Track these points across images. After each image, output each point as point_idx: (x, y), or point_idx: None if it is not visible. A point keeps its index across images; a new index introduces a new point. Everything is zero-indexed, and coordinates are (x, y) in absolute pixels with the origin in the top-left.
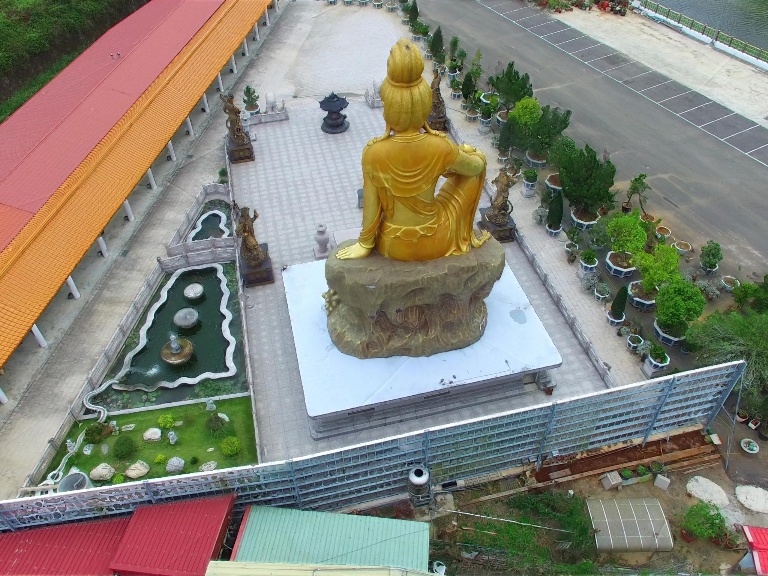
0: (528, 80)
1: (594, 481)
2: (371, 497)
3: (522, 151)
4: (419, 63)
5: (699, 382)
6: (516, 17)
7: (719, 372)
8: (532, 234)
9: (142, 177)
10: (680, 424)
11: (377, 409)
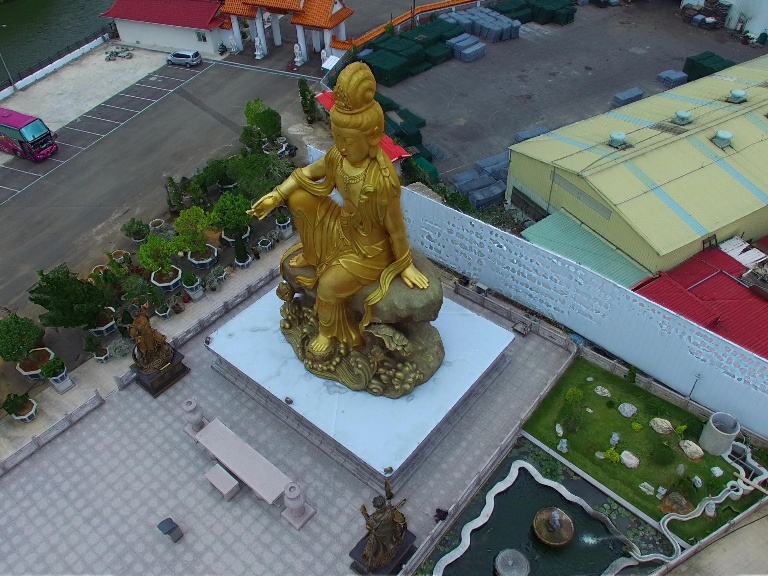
0: None
1: None
2: None
3: None
4: None
5: None
6: None
7: None
8: None
9: None
10: None
11: None
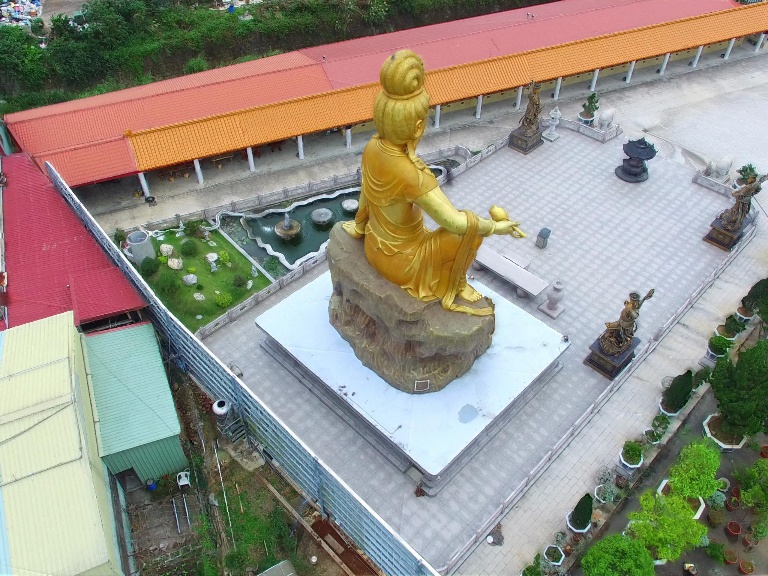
0: None
1: None
2: None
3: None
4: (397, 78)
5: None
6: None
7: None
8: (643, 393)
9: None
10: None
11: None
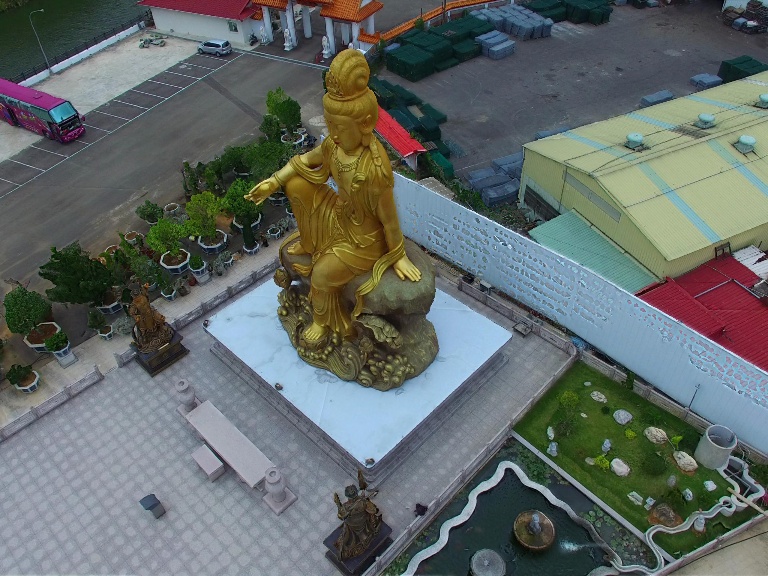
0: None
1: None
2: None
3: None
4: None
5: None
6: None
7: None
8: None
9: None
10: None
11: None
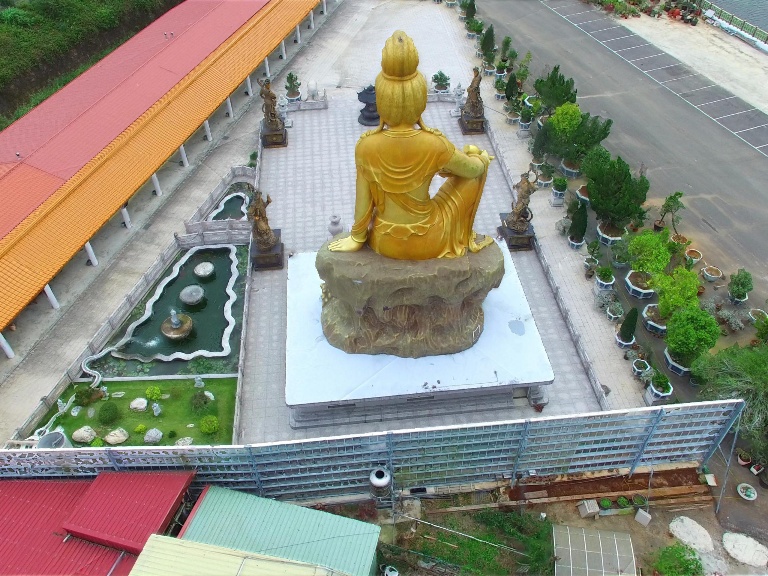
0: (572, 85)
1: (571, 507)
2: (338, 493)
3: (559, 158)
4: (412, 57)
5: (692, 417)
6: (579, 20)
7: (714, 409)
8: (553, 245)
9: (172, 154)
10: (672, 459)
11: (358, 405)
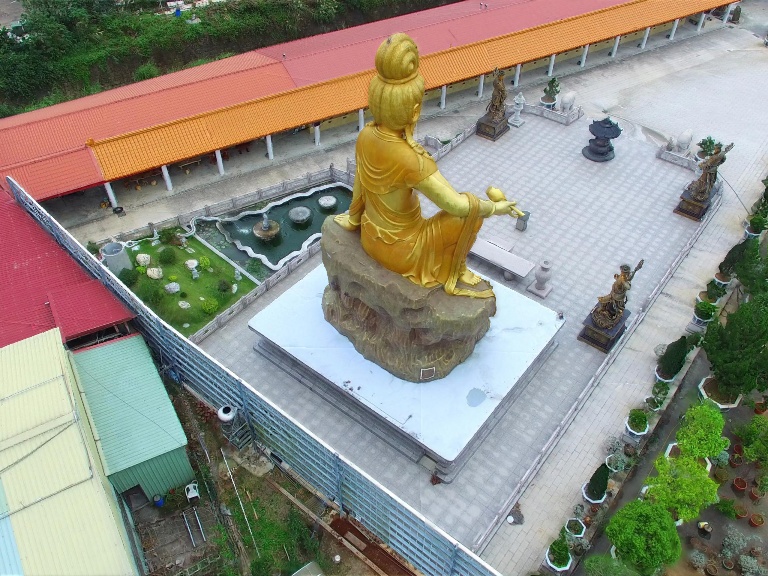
0: None
1: (369, 575)
2: None
3: None
4: (394, 61)
5: None
6: None
7: None
8: (638, 363)
9: None
10: None
11: None
